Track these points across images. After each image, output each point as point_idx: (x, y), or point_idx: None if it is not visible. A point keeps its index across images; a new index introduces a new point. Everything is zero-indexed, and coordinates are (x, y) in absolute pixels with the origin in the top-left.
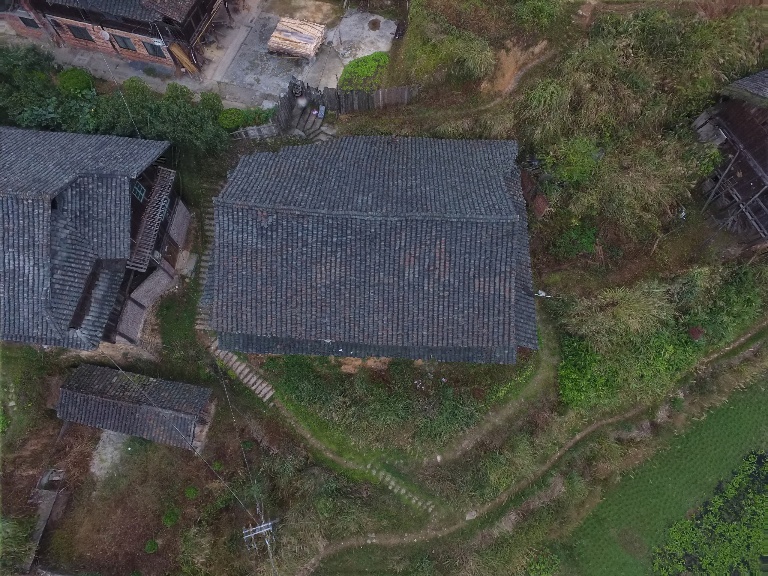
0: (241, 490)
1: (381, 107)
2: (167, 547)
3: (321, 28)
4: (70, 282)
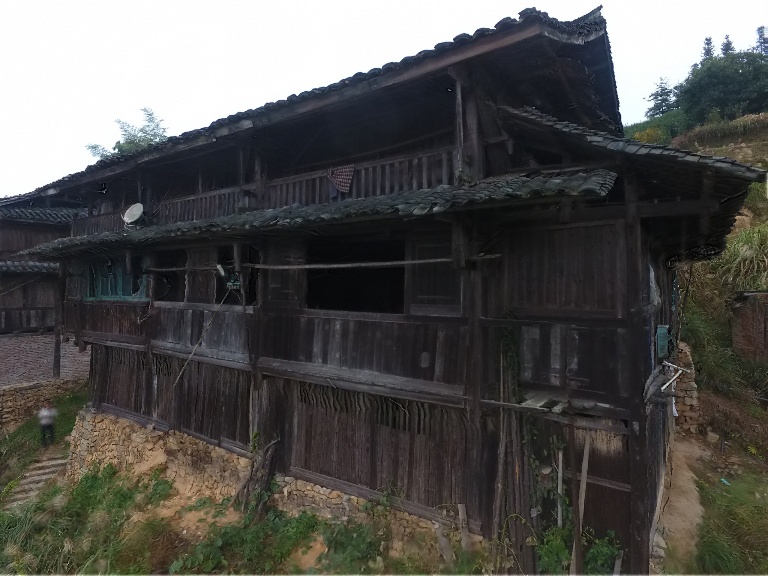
0: None
1: None
2: None
3: None
4: (30, 214)
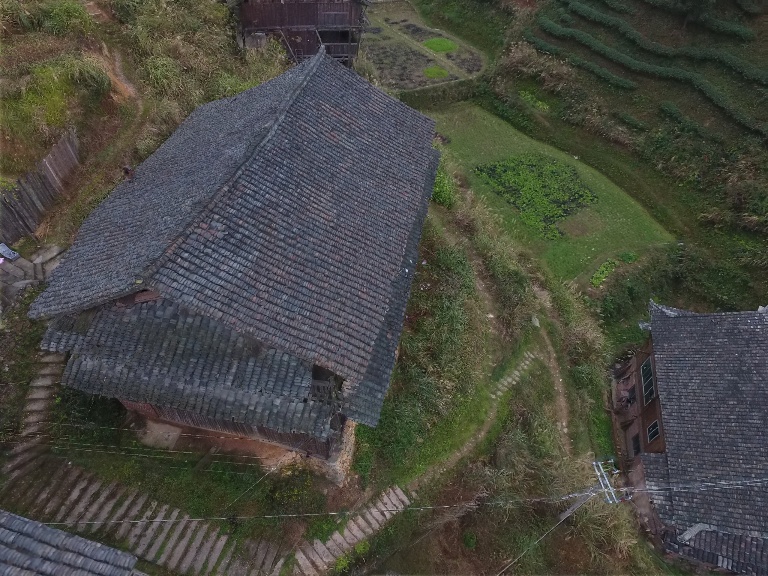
0: (529, 567)
1: (62, 188)
2: None
3: None
4: None
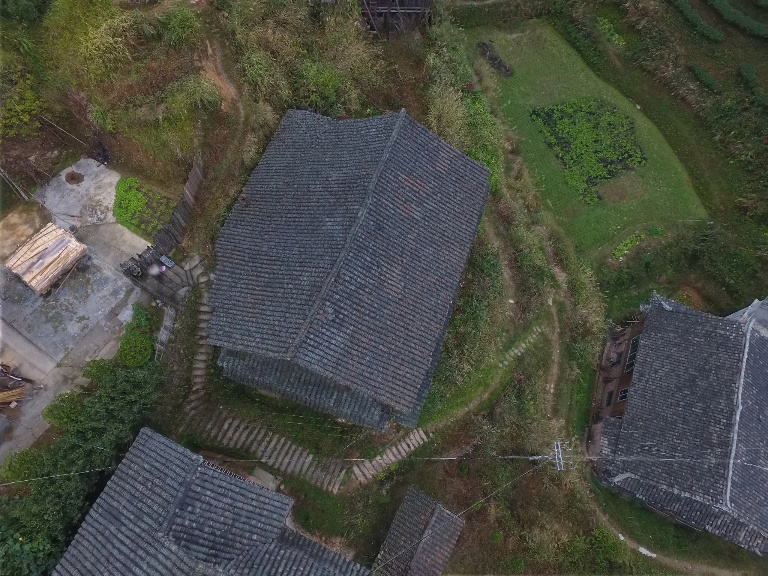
0: None
1: (193, 203)
2: (540, 574)
3: (52, 227)
4: None
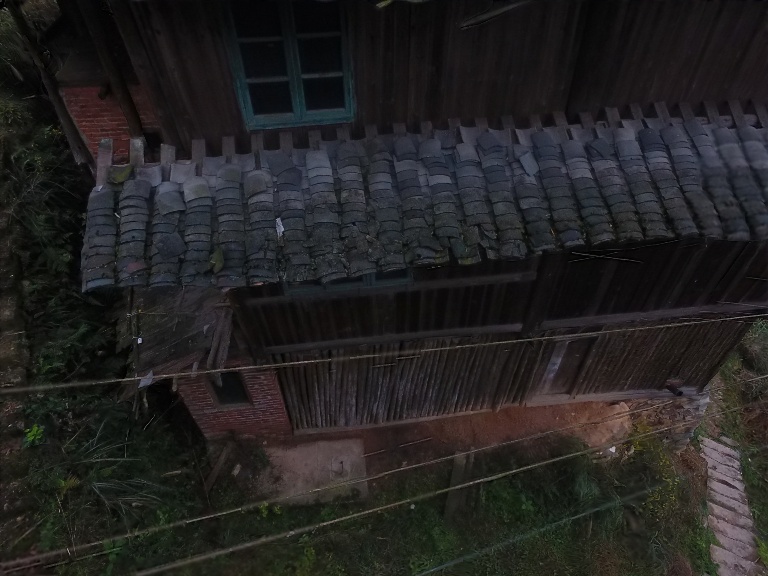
0: None
1: None
2: None
3: None
4: None
